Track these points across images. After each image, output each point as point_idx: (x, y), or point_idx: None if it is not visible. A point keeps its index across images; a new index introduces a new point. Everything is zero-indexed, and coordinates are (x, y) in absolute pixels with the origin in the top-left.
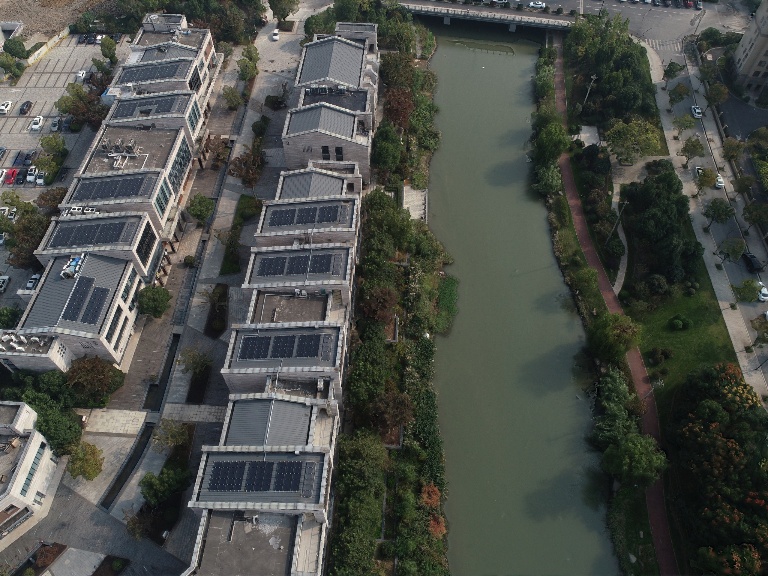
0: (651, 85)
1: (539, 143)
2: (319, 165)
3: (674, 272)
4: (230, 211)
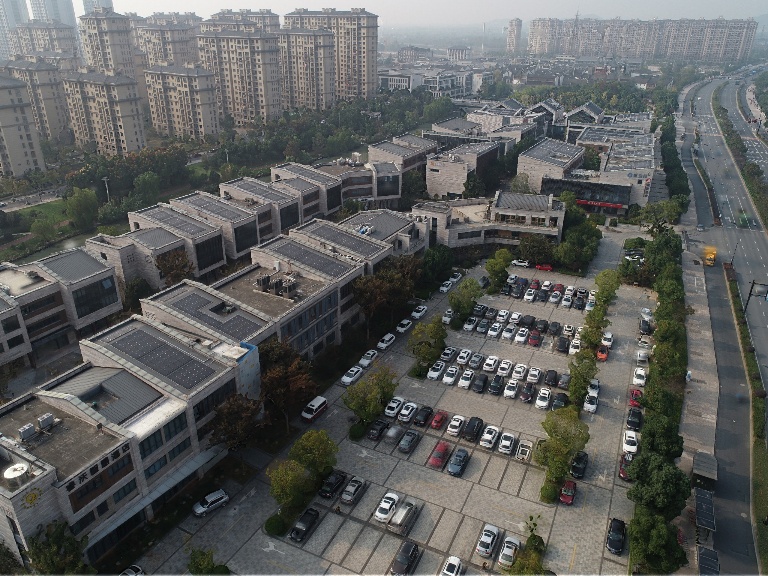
0: None
1: None
2: None
3: None
4: None
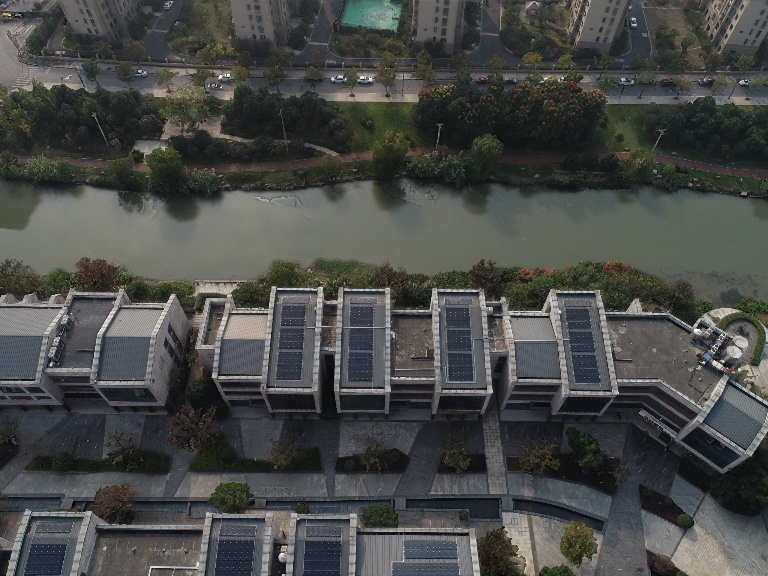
0: None
1: (165, 174)
2: (203, 340)
3: (330, 112)
4: (217, 480)
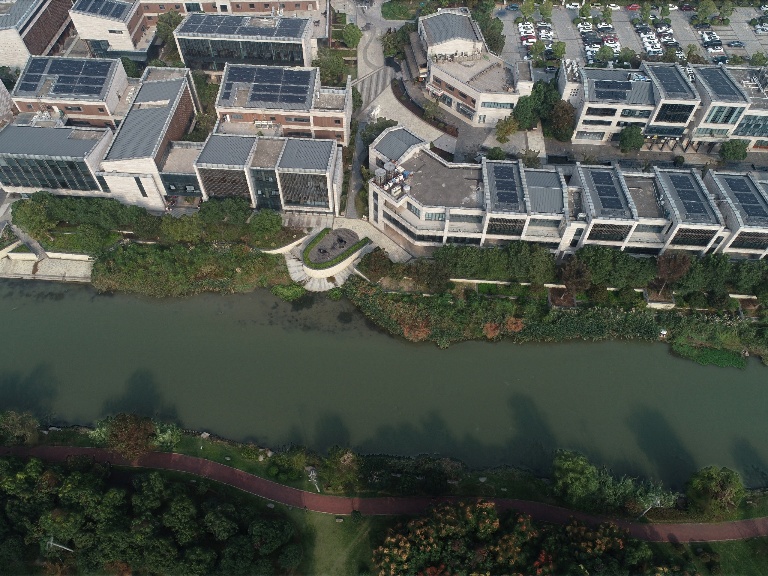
0: None
1: None
2: None
3: None
4: None
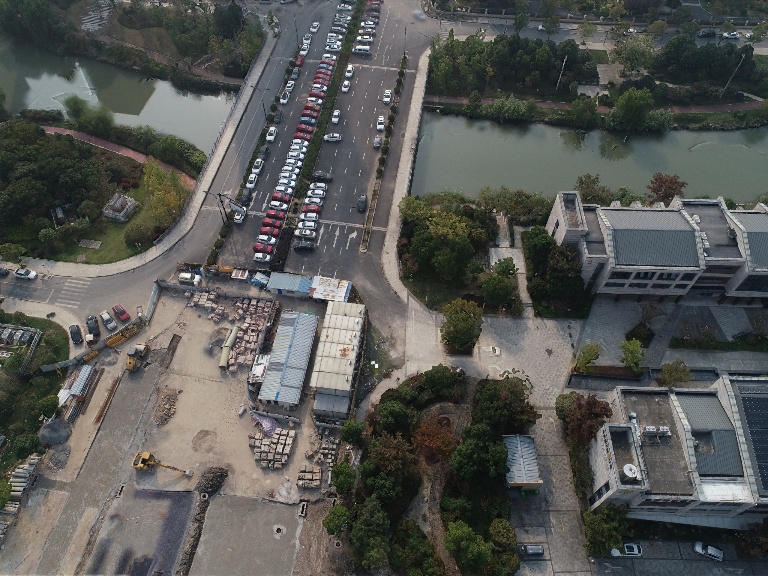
0: (531, 40)
1: None
2: None
3: (754, 61)
4: None
